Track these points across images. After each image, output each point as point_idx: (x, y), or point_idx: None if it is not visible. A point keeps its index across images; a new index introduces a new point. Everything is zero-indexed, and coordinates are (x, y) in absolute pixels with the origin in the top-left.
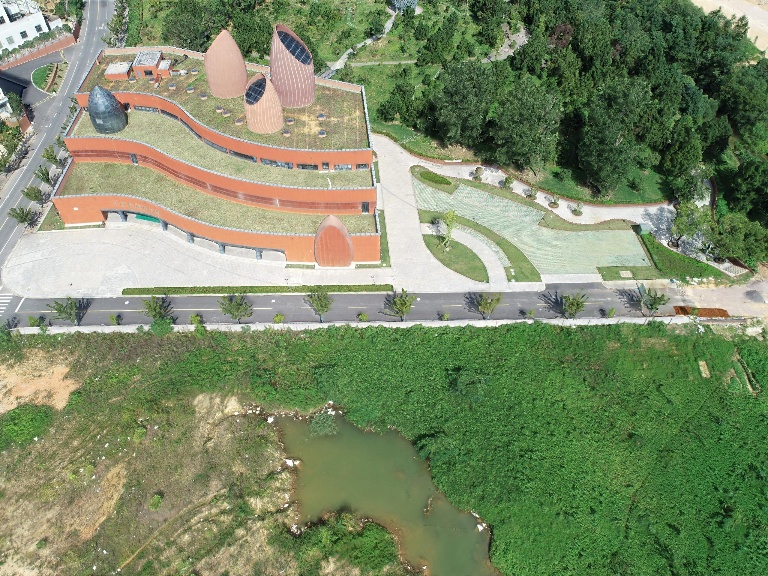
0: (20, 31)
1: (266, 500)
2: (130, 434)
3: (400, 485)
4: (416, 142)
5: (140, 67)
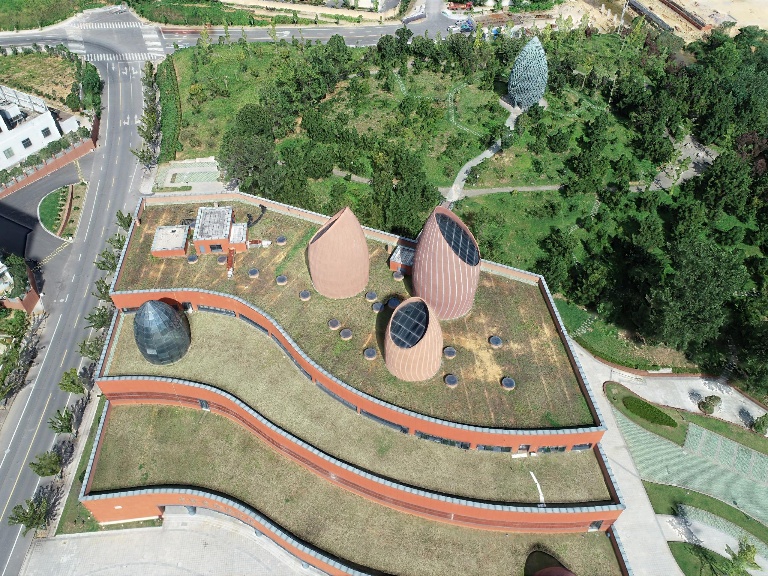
0: (22, 139)
1: None
2: None
3: None
4: (596, 333)
5: (204, 241)
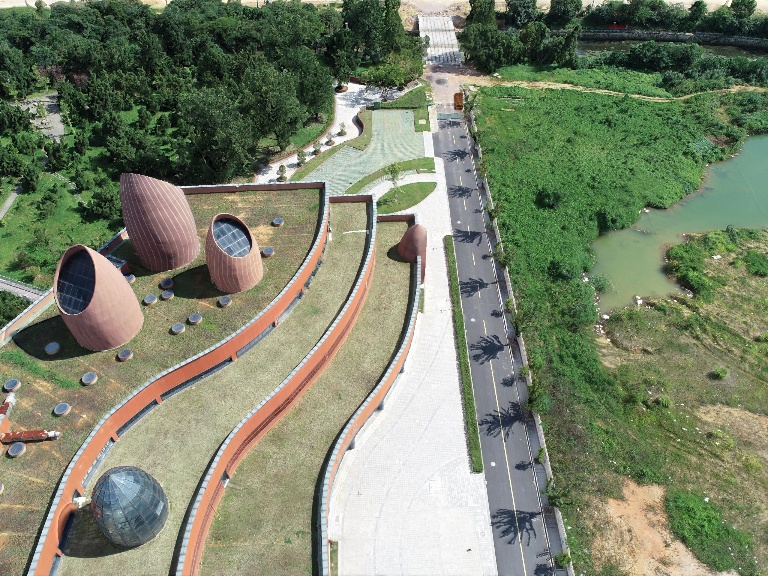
0: None
1: (682, 307)
2: (667, 411)
3: (632, 245)
4: None
5: None
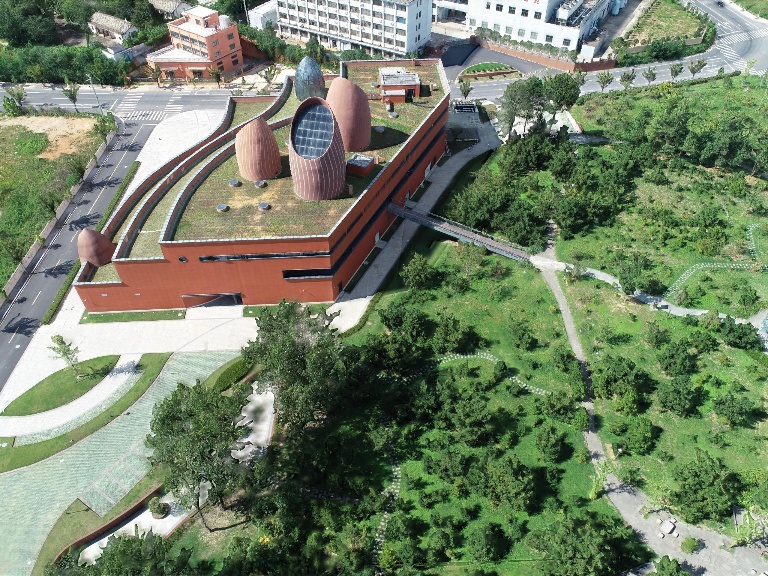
0: (548, 34)
1: None
2: None
3: None
4: None
5: None
